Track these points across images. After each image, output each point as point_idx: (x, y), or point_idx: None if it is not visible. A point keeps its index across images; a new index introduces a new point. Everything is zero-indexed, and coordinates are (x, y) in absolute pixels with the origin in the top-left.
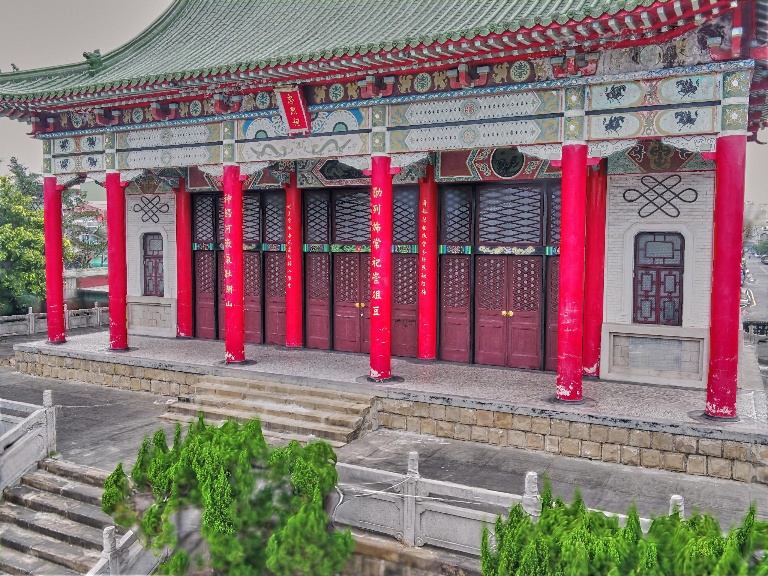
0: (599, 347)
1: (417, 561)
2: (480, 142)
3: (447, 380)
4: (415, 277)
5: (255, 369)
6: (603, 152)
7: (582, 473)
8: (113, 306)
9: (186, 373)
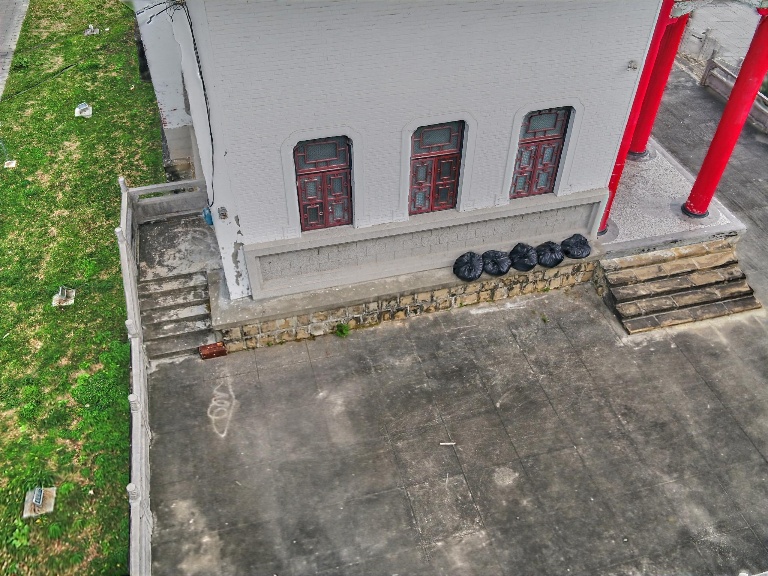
0: None
1: None
2: None
3: None
4: None
5: None
6: None
7: None
8: None
9: None
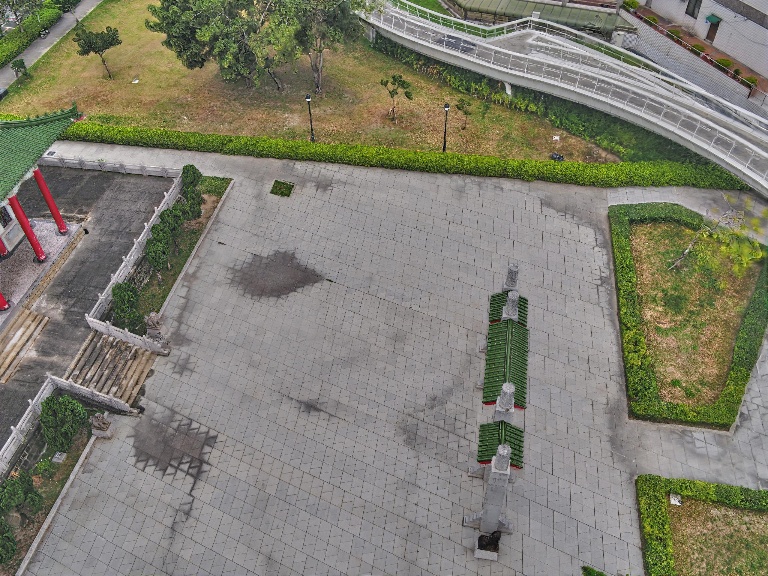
0: None
1: None
2: None
3: (7, 290)
4: None
5: None
6: None
7: (75, 265)
8: None
9: None
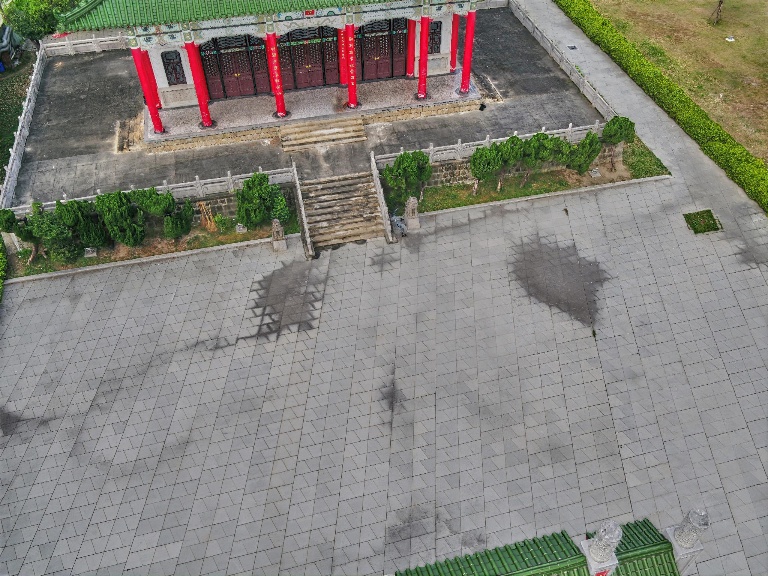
0: (414, 66)
1: (435, 166)
2: (392, 17)
3: (373, 98)
4: (335, 50)
5: (300, 117)
6: (434, 17)
7: (438, 122)
8: (205, 107)
9: (268, 128)
